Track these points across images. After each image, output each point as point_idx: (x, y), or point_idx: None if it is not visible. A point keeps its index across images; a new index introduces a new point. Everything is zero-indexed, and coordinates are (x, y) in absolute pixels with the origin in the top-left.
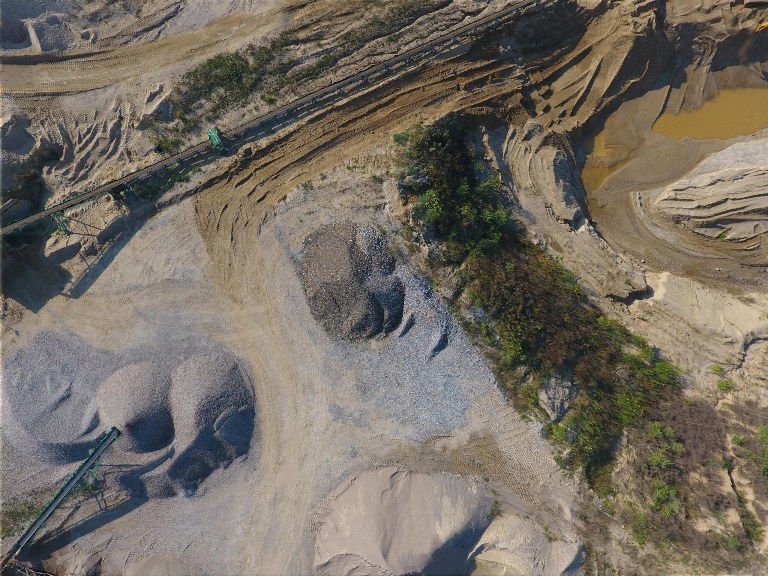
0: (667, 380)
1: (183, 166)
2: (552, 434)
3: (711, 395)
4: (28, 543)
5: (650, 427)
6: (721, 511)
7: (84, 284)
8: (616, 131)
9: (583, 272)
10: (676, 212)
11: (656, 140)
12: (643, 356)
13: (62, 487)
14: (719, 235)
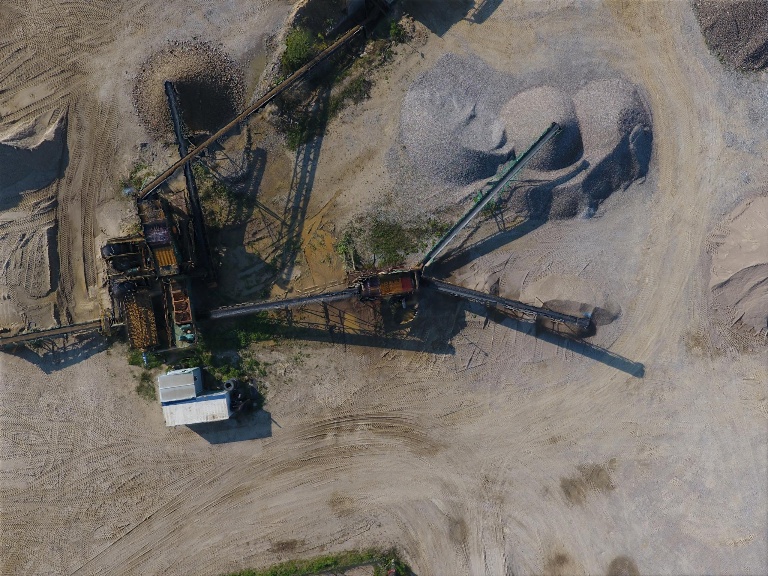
0: None
1: None
2: None
3: None
4: None
5: None
6: None
7: (487, 10)
8: None
9: None
10: None
11: None
12: None
13: (488, 190)
14: None
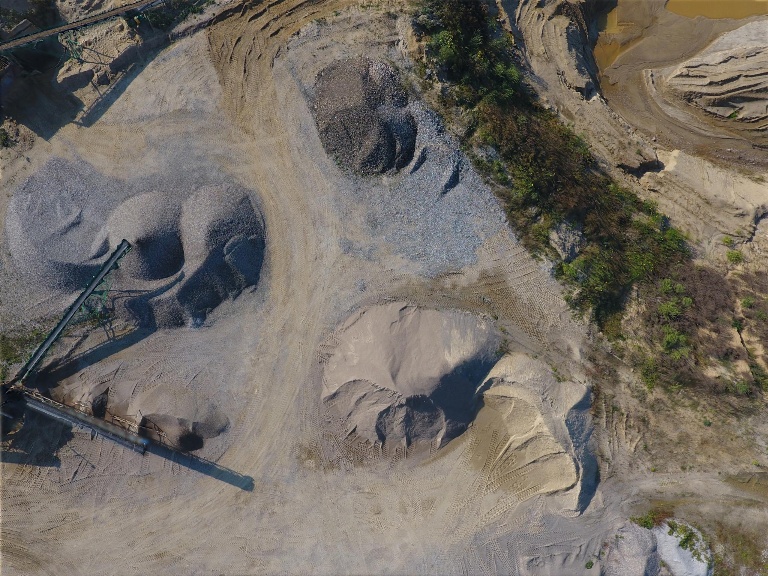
0: (677, 247)
1: None
2: (562, 275)
3: (721, 265)
4: (35, 370)
5: (660, 283)
6: (731, 362)
7: (96, 113)
8: (629, 8)
9: (594, 141)
10: (688, 89)
11: (669, 18)
12: (653, 224)
13: (71, 305)
14: (731, 114)
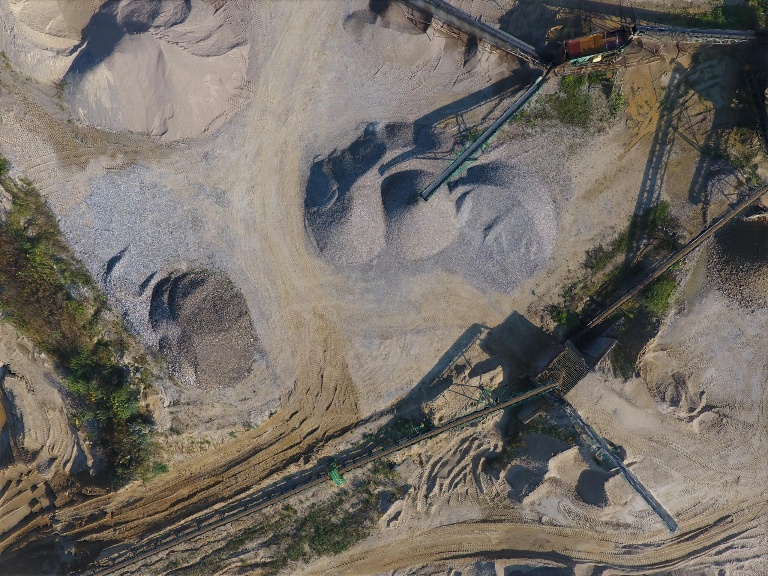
0: None
1: (369, 449)
2: None
3: None
4: None
5: None
6: None
7: (468, 338)
8: None
9: None
10: None
11: None
12: None
13: None
14: None
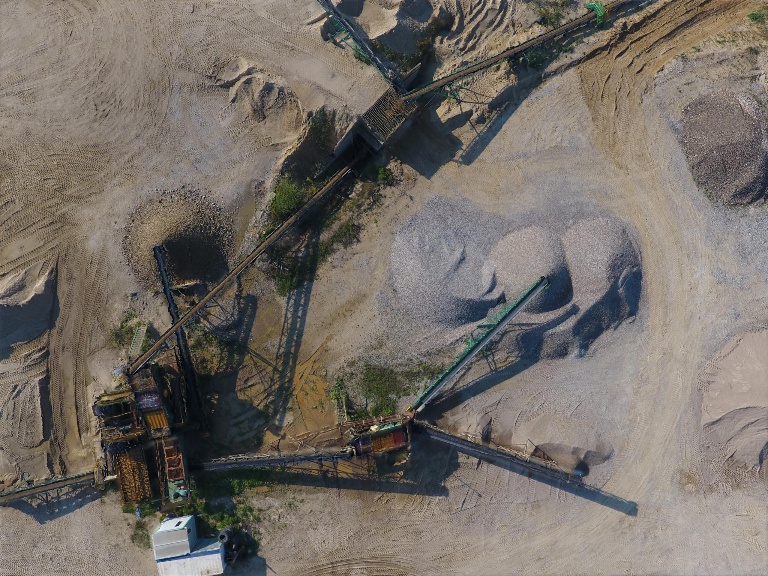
0: None
1: (566, 38)
2: None
3: None
4: None
5: None
6: None
7: (475, 151)
8: None
9: None
10: None
11: None
12: None
13: None
14: None
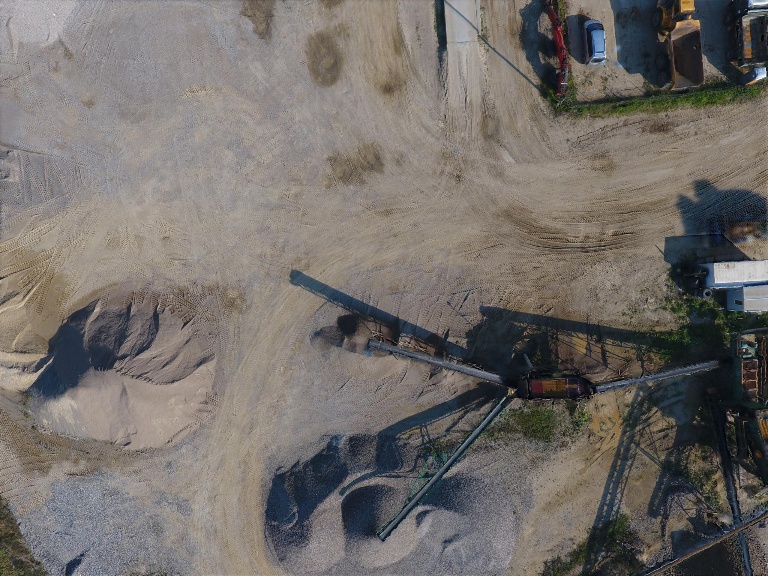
0: None
1: None
2: None
3: None
4: None
5: None
6: None
7: None
8: None
9: None
10: None
11: None
12: None
13: None
14: None
